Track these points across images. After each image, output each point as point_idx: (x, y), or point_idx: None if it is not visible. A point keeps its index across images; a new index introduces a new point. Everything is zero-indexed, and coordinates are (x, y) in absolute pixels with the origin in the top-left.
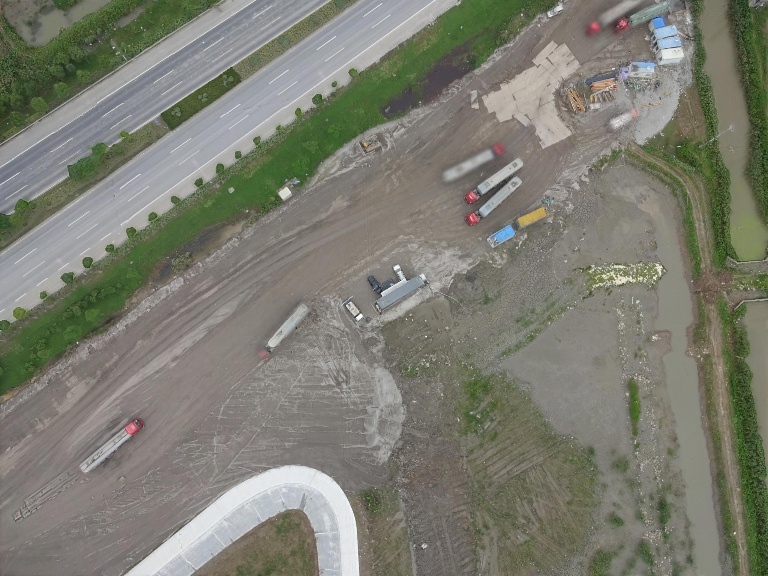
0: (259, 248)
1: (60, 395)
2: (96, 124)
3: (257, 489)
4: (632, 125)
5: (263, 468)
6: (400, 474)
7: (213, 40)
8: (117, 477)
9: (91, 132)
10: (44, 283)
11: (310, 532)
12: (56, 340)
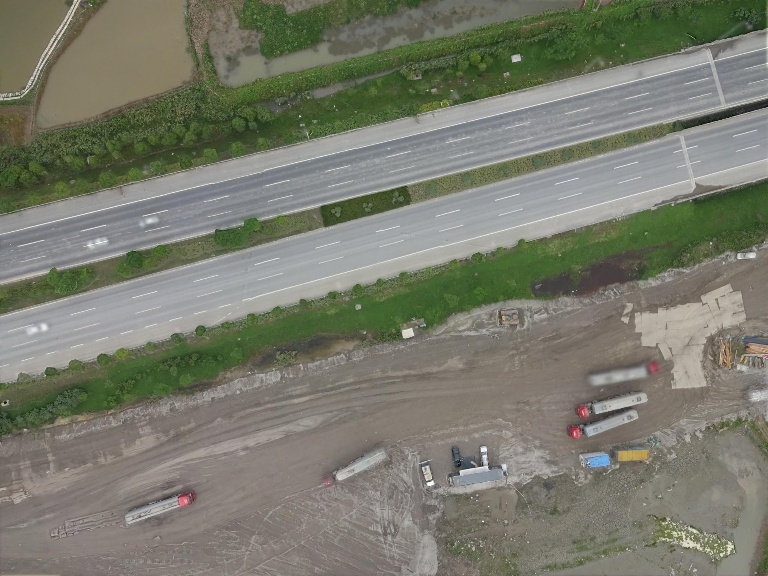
0: (363, 375)
1: (130, 439)
2: (256, 191)
3: None
4: None
5: None
6: None
7: (399, 150)
8: (154, 535)
9: (248, 197)
10: (152, 327)
11: None
12: (144, 385)
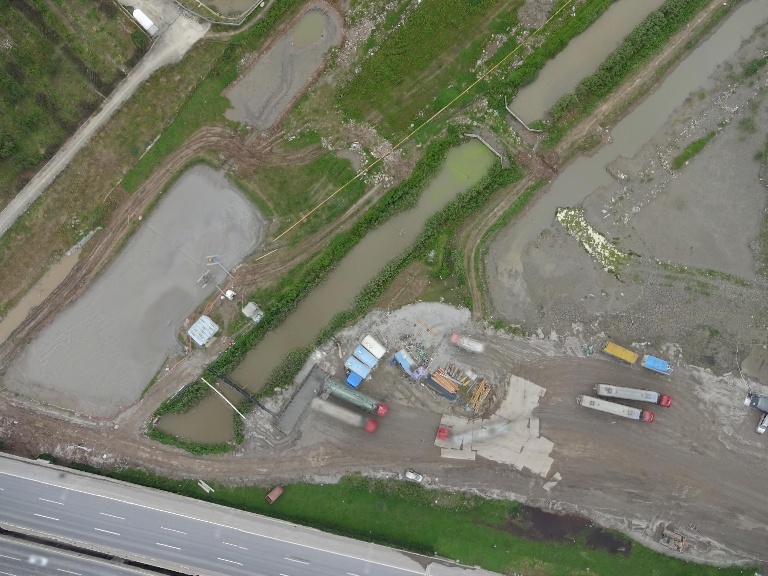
0: None
1: None
2: None
3: None
4: (459, 331)
5: None
6: None
7: None
8: None
9: None
10: None
11: None
12: None
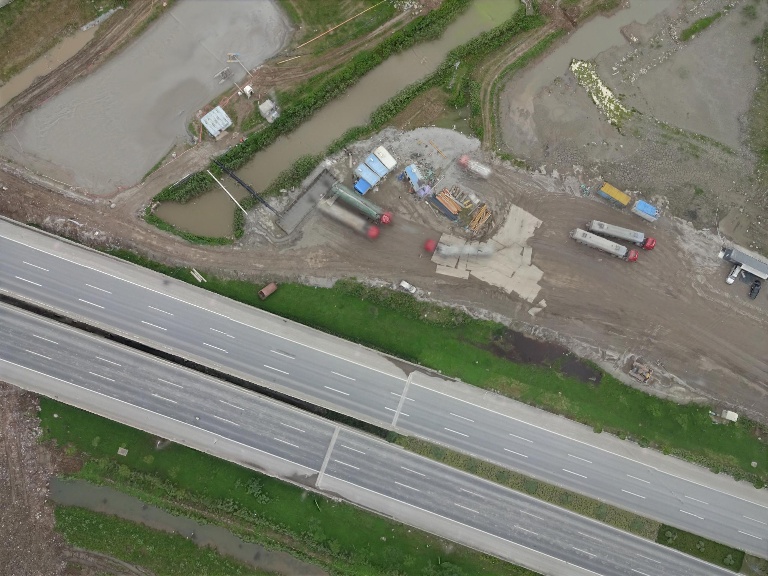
0: None
1: None
2: None
3: None
4: (468, 157)
5: None
6: None
7: None
8: None
9: None
10: None
11: None
12: None
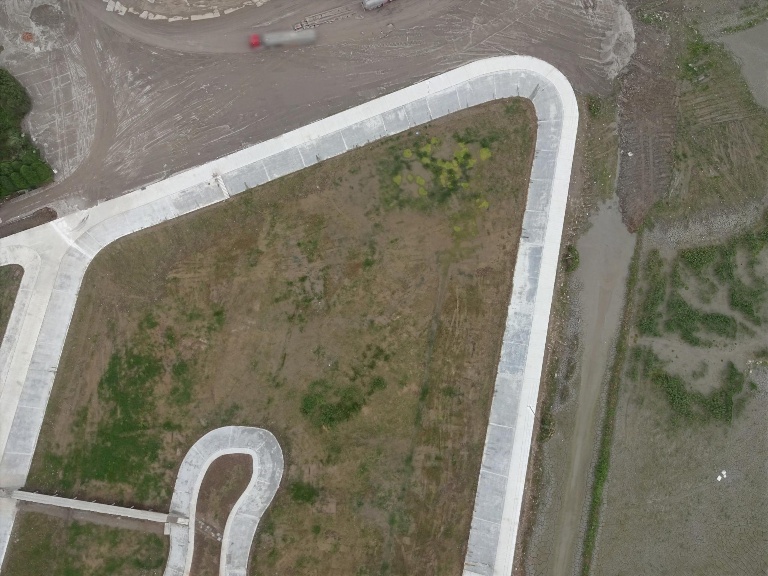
0: None
1: None
2: None
3: (501, 67)
4: None
5: (510, 52)
6: (621, 94)
7: None
8: (387, 23)
9: None
10: None
11: (534, 119)
12: None
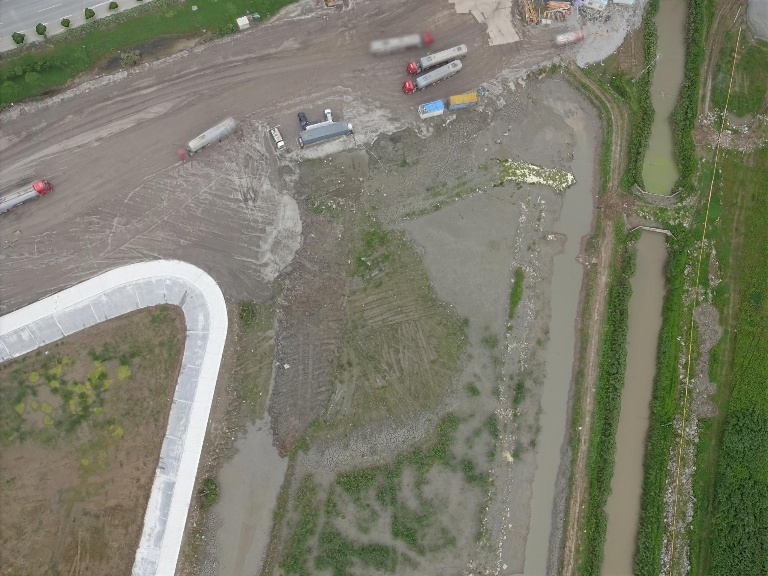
0: (206, 63)
1: None
2: None
3: (143, 274)
4: (576, 47)
5: (154, 257)
6: (282, 296)
7: None
8: (13, 230)
9: None
10: None
11: (183, 329)
12: None
